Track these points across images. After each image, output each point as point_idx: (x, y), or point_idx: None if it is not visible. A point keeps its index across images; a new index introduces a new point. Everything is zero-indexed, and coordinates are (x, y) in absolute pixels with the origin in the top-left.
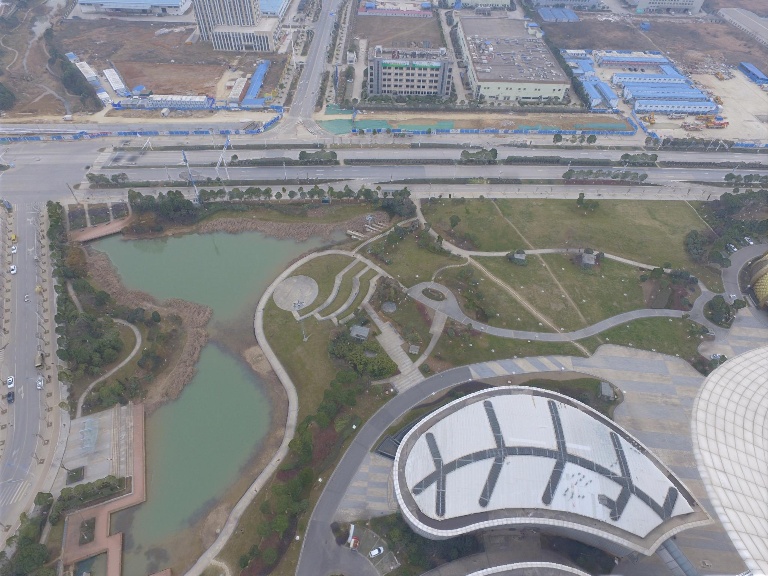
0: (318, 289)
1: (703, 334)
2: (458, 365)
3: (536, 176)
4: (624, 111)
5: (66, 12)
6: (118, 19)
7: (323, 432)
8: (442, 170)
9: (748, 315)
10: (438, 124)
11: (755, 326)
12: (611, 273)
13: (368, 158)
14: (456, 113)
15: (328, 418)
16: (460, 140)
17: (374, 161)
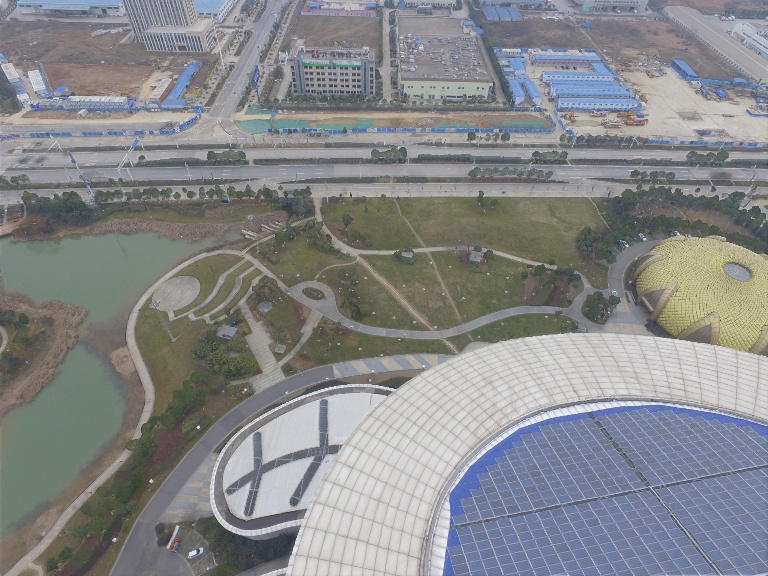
0: (200, 289)
1: (574, 330)
2: (322, 364)
3: (444, 174)
4: (547, 109)
5: (5, 14)
6: (56, 20)
7: (169, 433)
8: (351, 169)
9: (626, 311)
10: (357, 123)
11: (630, 322)
12: (497, 270)
13: (279, 158)
14: (378, 112)
15: (173, 419)
16: (376, 139)
17: (284, 161)
